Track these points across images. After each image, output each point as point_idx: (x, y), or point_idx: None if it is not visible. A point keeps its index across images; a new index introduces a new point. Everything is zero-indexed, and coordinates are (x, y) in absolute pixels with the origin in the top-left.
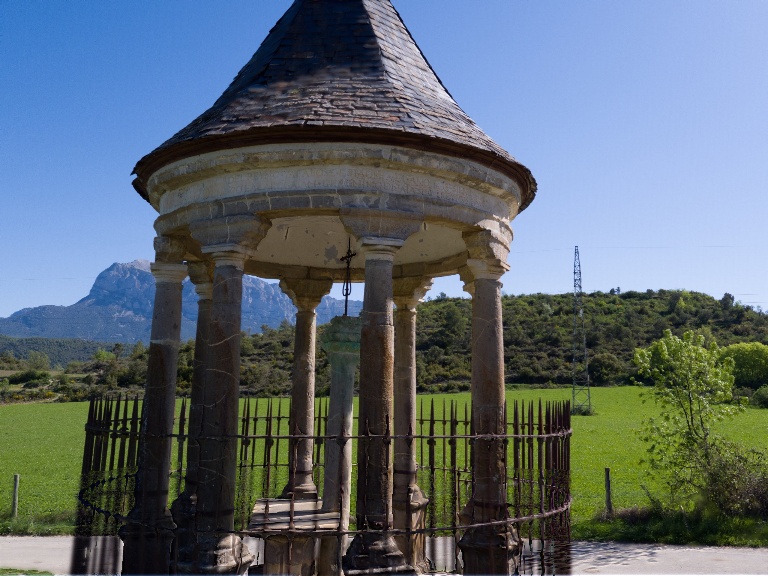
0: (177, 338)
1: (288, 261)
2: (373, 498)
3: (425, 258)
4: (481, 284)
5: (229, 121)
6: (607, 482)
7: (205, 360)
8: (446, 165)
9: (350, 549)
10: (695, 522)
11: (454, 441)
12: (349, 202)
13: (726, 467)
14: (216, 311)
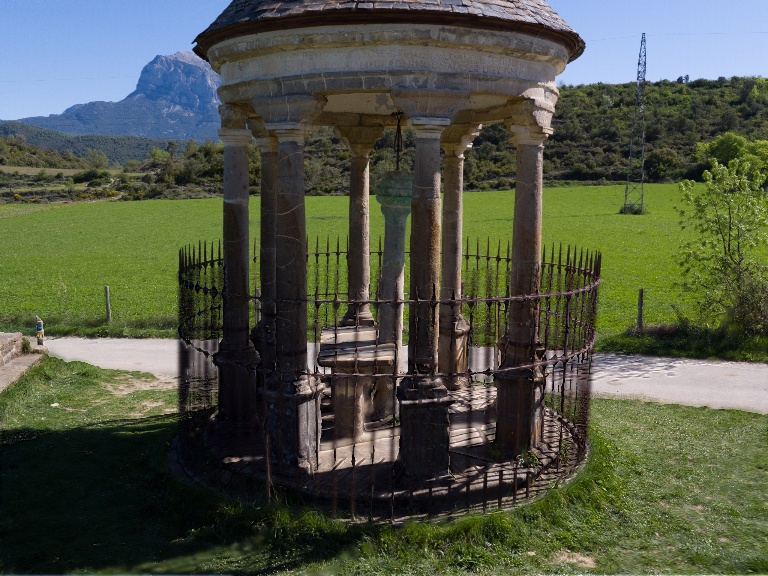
0: (246, 197)
1: (341, 109)
2: (422, 345)
3: (473, 105)
4: (523, 149)
5: None
6: (640, 301)
7: (270, 209)
8: (493, 40)
9: (403, 383)
10: (718, 339)
11: None
12: (399, 83)
13: (755, 291)
14: (282, 184)
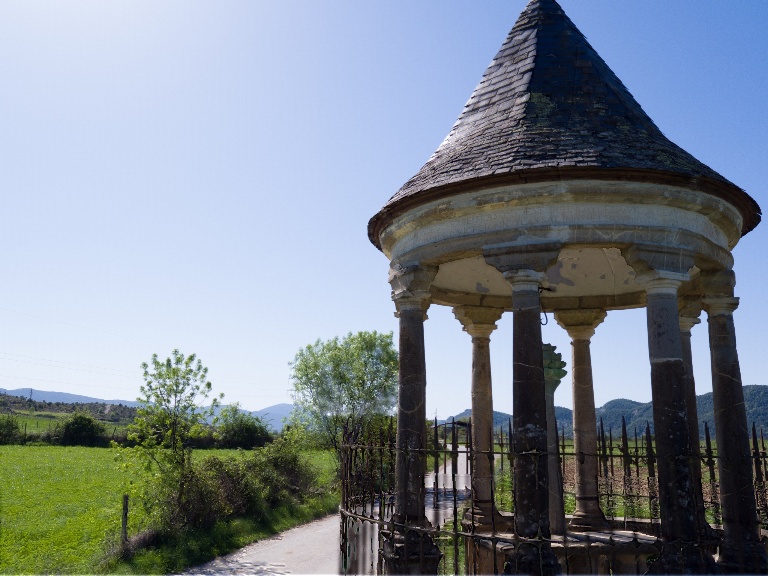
0: None
1: None
2: None
3: None
4: None
5: None
6: (127, 511)
7: None
8: None
9: None
10: None
11: None
12: None
13: (208, 479)
14: None
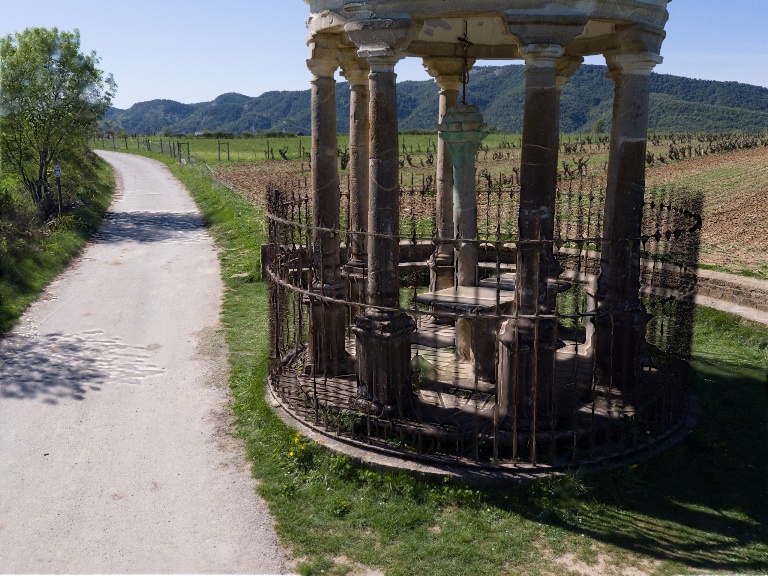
0: None
1: None
2: None
3: None
4: None
5: None
6: None
7: None
8: None
9: None
10: None
11: None
12: None
13: None
14: None
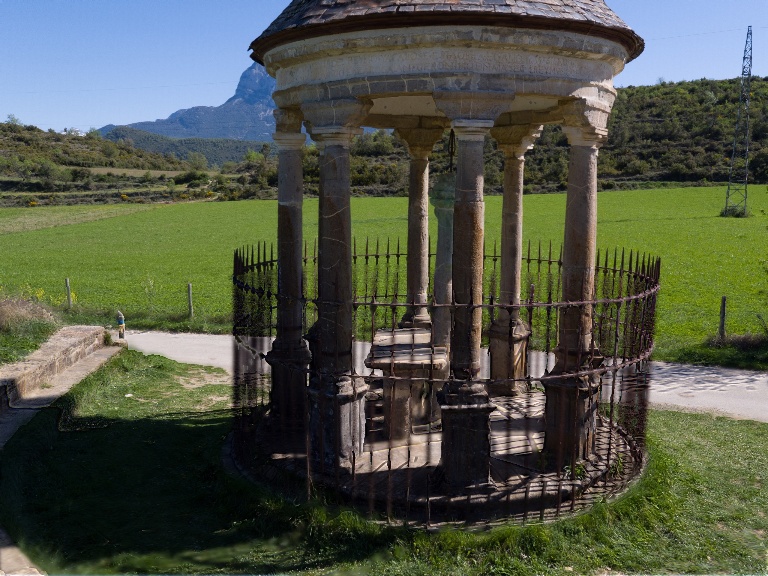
0: (300, 200)
1: (400, 111)
2: (463, 350)
3: (534, 106)
4: (576, 151)
5: (328, 6)
6: (722, 309)
7: None
8: (539, 39)
9: (444, 388)
10: None
11: (531, 309)
12: (442, 85)
13: None
14: (328, 187)
